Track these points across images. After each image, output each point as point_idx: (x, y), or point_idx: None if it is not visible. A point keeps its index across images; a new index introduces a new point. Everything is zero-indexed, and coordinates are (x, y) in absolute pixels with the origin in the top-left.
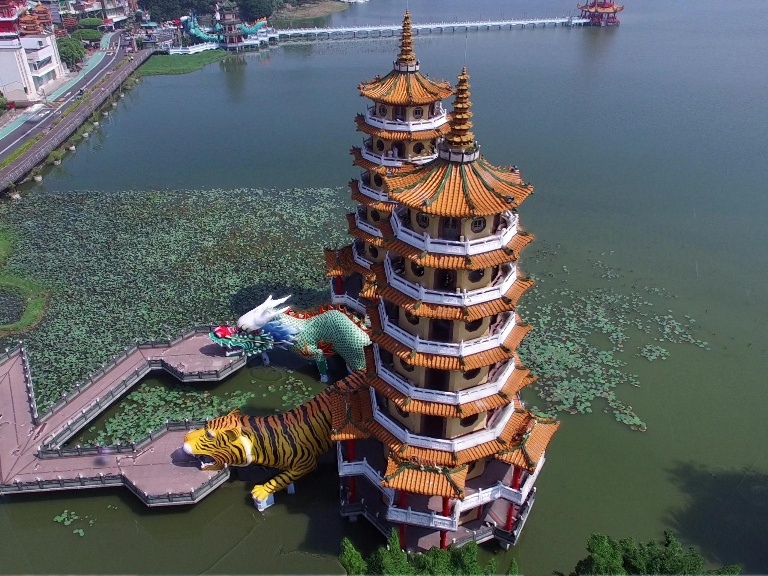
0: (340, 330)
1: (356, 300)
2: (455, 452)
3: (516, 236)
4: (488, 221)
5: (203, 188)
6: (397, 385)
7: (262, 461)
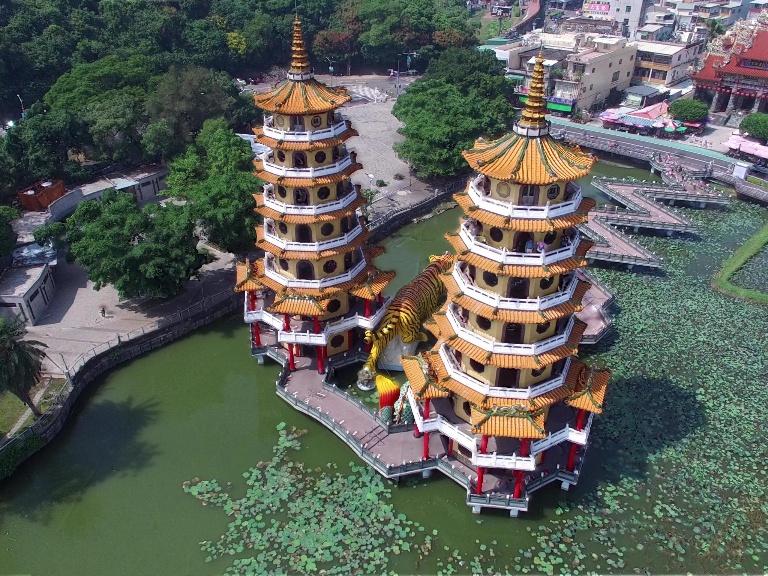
0: None
1: None
2: None
3: None
4: None
5: None
6: None
7: None
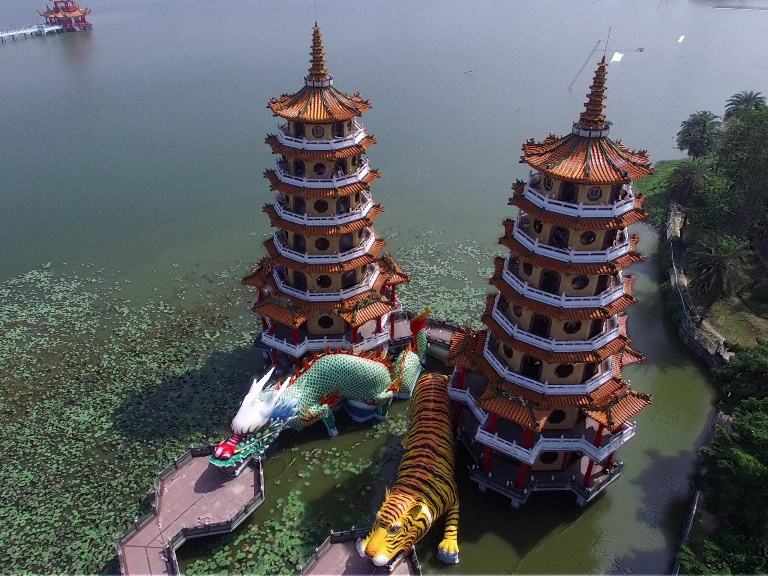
0: (349, 371)
1: (323, 339)
2: (614, 377)
3: None
4: None
5: None
6: (576, 348)
7: (436, 517)
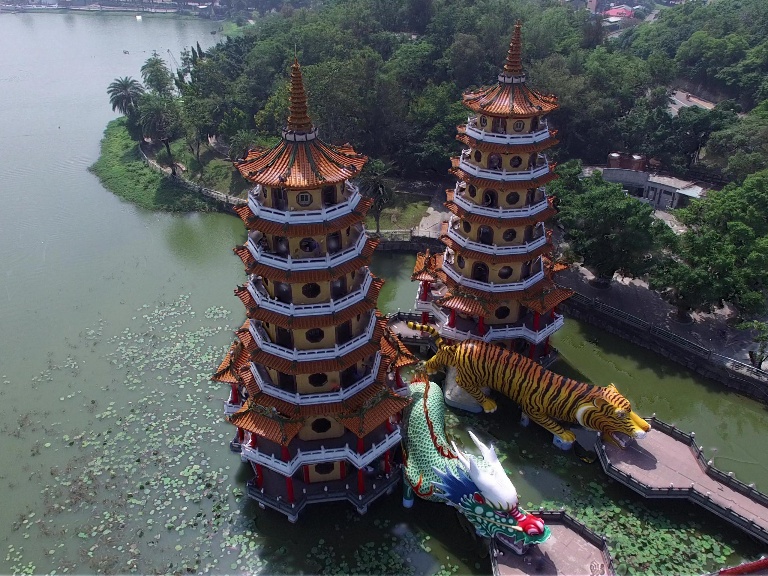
0: None
1: None
2: None
3: None
4: None
5: None
6: None
7: None
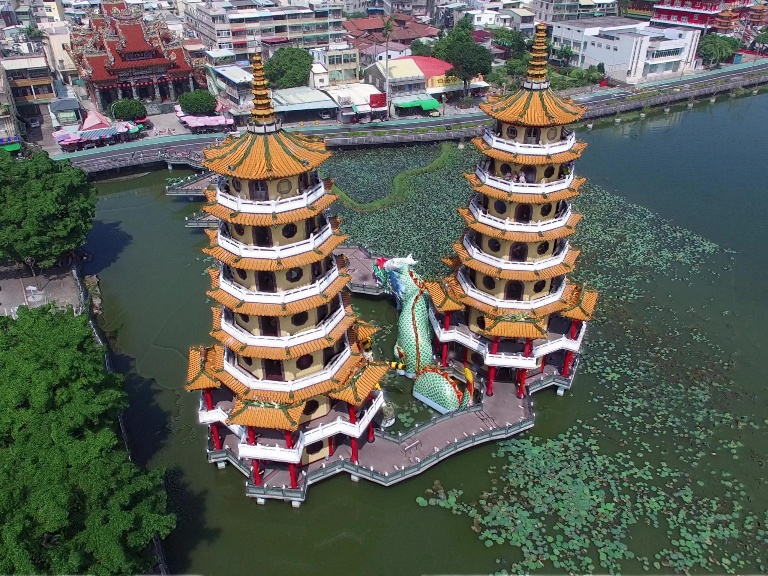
0: (405, 303)
1: None
2: (223, 368)
3: (270, 215)
4: (242, 185)
5: (613, 191)
6: None
7: None
